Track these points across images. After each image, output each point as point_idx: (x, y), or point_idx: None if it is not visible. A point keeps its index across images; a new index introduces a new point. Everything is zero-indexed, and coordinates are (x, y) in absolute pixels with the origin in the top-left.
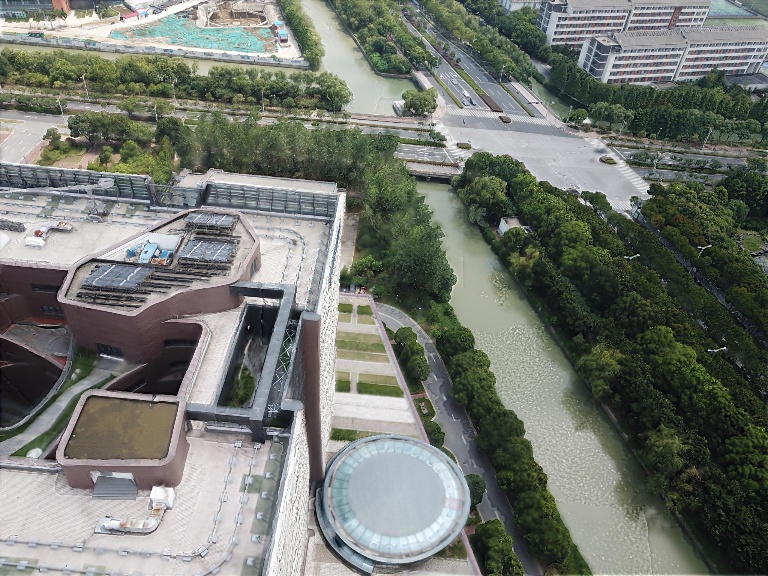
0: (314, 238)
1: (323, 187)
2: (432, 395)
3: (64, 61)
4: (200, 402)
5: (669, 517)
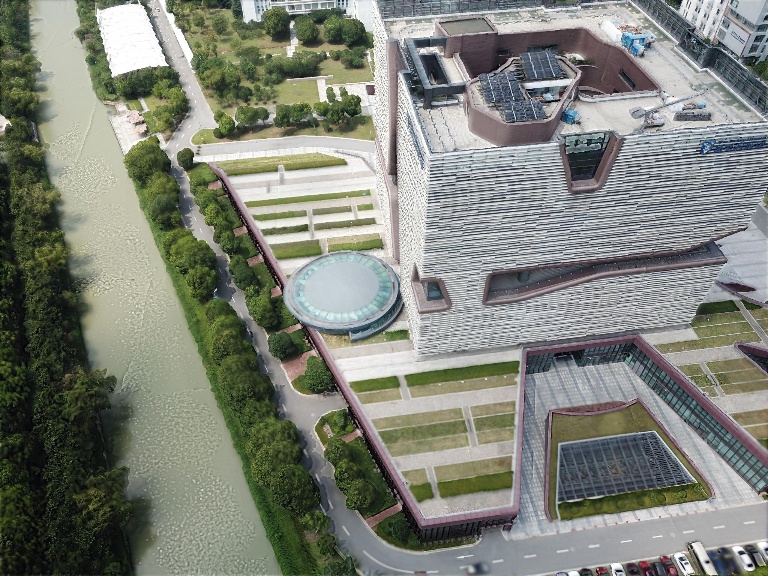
0: None
1: None
2: (320, 452)
3: None
4: (449, 65)
5: None
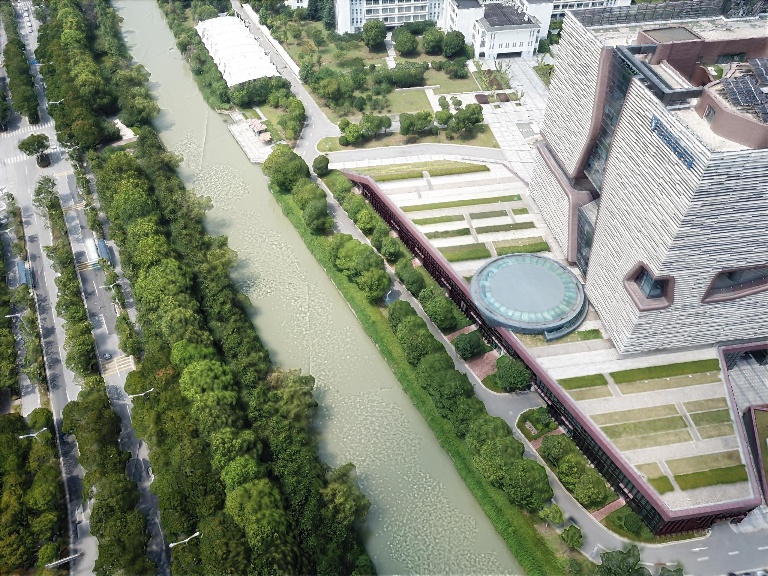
0: None
1: None
2: (528, 448)
3: None
4: (658, 71)
5: None
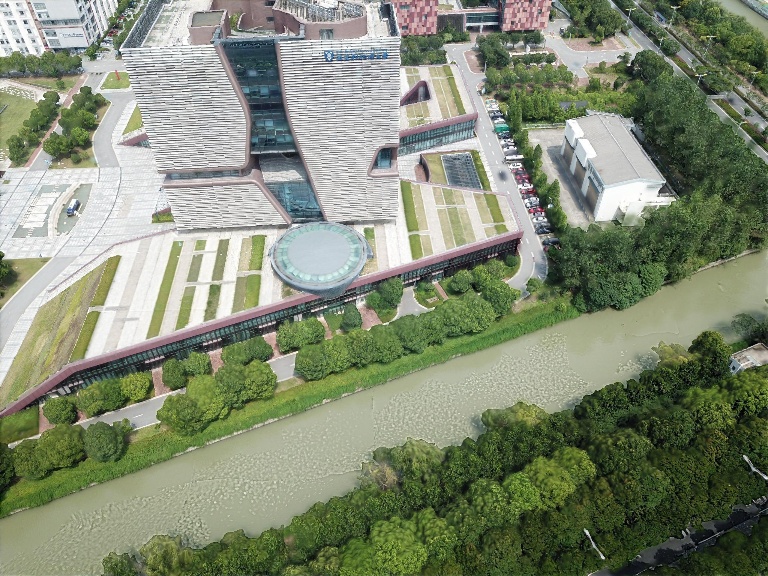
0: None
1: (649, 173)
2: None
3: (727, 24)
4: None
5: None
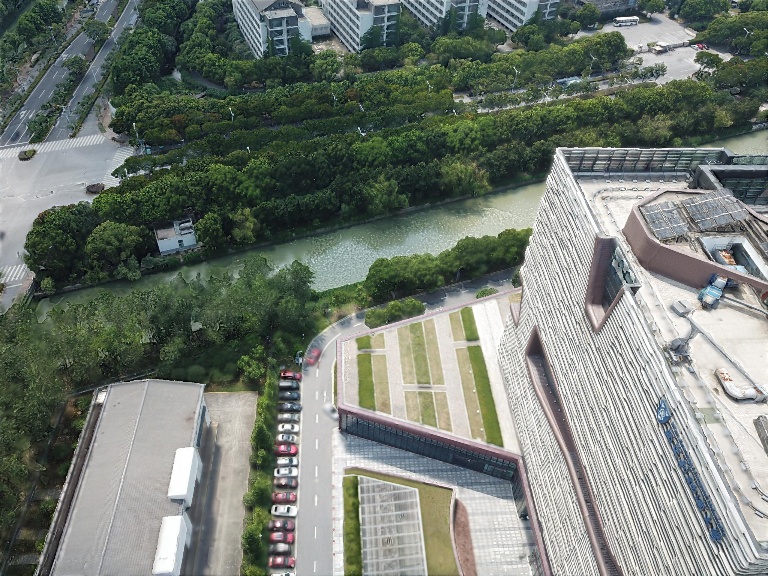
0: (592, 186)
1: (123, 399)
2: None
3: None
4: None
5: (483, 198)
